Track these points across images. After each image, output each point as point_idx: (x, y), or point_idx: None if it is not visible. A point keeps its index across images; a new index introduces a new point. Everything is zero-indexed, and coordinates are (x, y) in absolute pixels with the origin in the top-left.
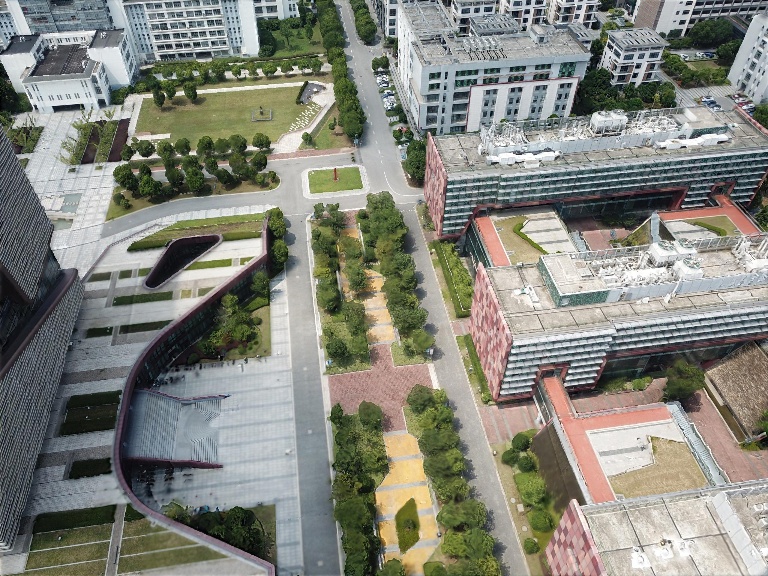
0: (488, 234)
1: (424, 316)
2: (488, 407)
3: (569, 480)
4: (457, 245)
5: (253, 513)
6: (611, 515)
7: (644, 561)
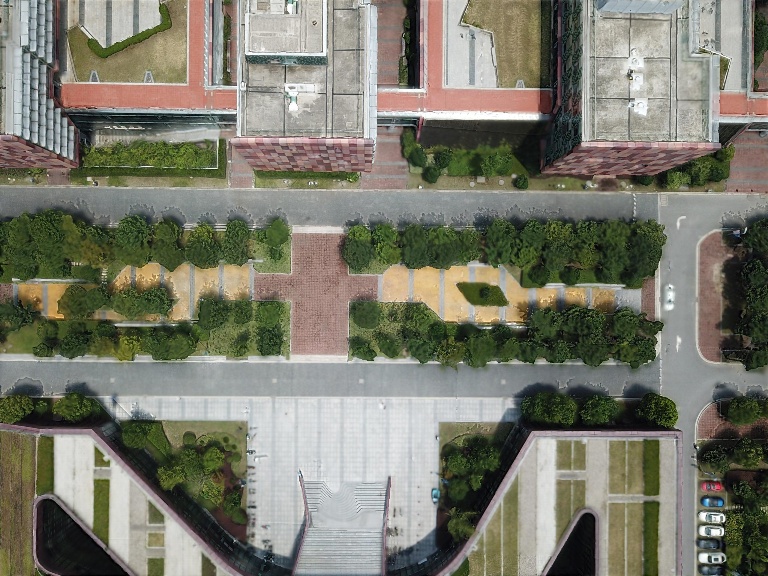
0: (103, 97)
1: (241, 225)
2: (362, 178)
3: (488, 126)
4: (80, 142)
5: (446, 445)
6: (598, 114)
7: (643, 103)
